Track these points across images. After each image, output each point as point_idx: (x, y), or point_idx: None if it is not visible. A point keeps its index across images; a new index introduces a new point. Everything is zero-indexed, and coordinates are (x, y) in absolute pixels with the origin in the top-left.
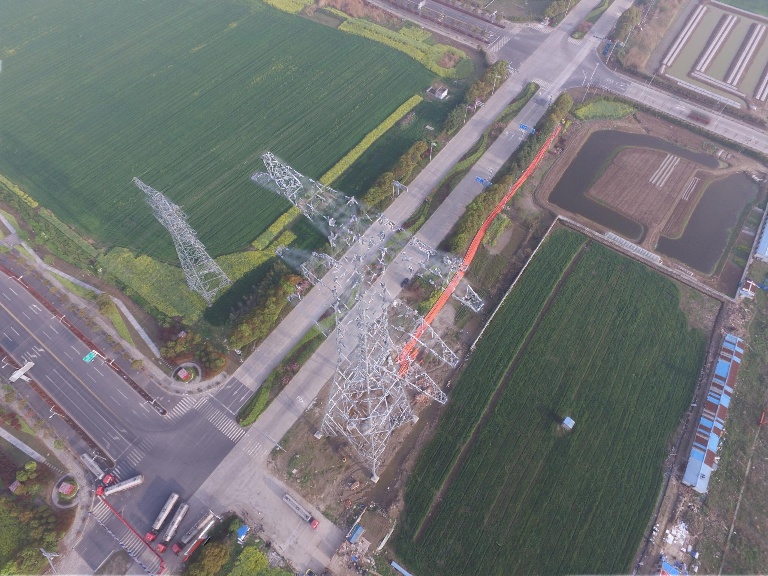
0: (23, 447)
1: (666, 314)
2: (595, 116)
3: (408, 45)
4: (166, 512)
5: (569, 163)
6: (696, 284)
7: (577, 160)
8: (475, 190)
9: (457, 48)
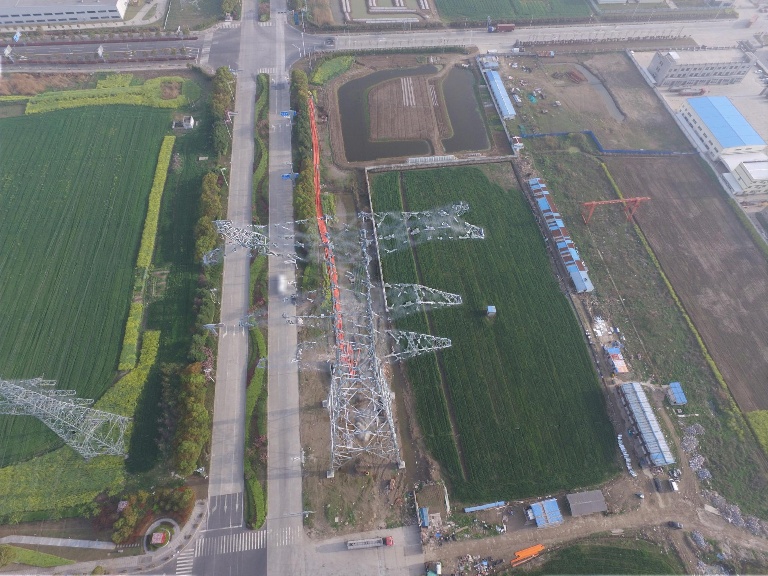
0: None
1: (487, 192)
2: (329, 77)
3: (118, 95)
4: None
5: (340, 124)
6: (487, 159)
7: (343, 118)
8: (287, 188)
9: (168, 76)
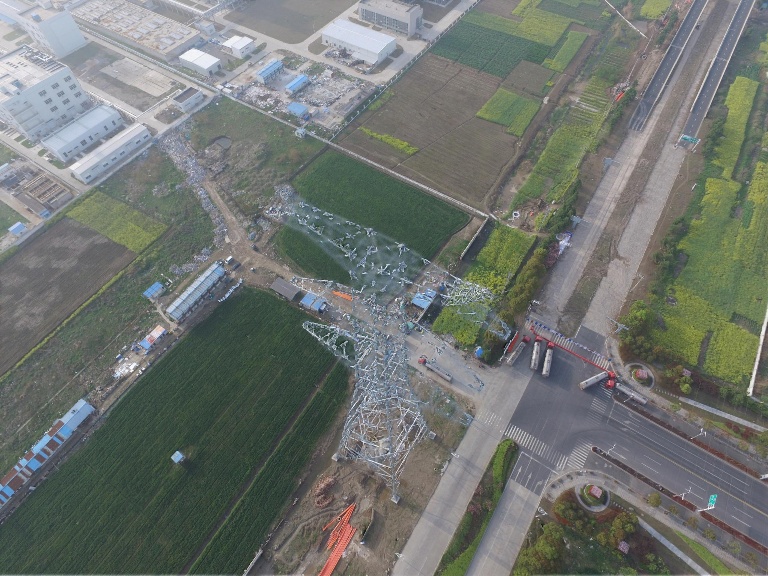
0: (709, 409)
1: None
2: None
3: None
4: (547, 361)
5: None
6: None
7: None
8: None
9: None
